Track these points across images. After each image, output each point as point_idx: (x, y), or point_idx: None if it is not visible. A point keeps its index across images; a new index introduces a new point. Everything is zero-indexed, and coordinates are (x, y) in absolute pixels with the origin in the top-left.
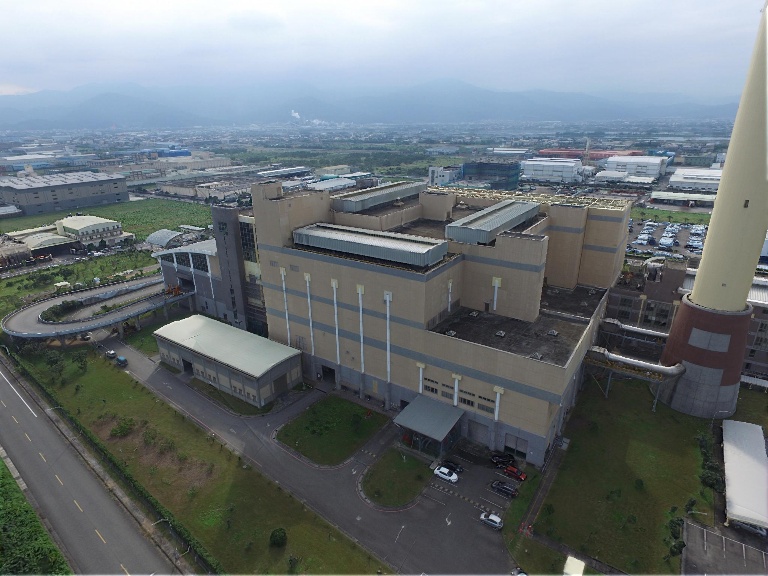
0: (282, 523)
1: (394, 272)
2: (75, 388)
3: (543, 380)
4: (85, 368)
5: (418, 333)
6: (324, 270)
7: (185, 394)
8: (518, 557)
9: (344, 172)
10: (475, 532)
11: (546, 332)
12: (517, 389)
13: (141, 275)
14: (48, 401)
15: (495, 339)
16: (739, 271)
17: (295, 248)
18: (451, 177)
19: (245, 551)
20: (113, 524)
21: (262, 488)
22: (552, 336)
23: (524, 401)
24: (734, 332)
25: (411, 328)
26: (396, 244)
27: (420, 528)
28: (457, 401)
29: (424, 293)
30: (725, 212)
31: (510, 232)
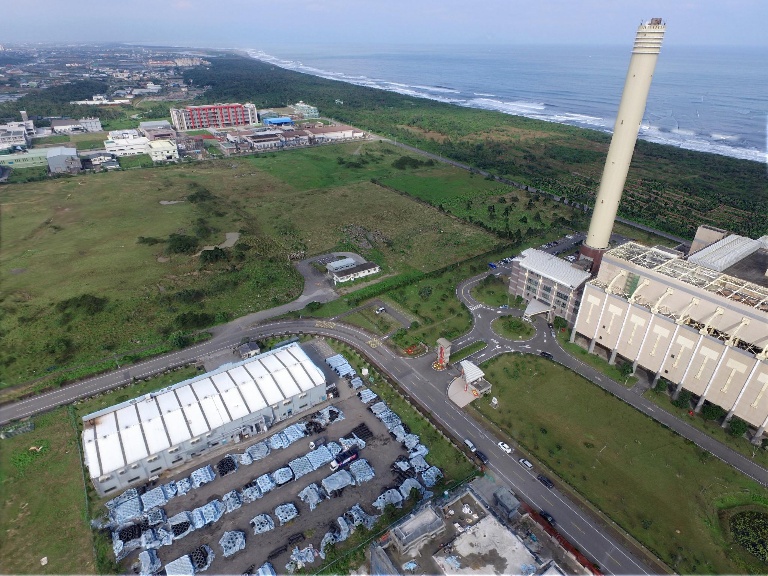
0: None
1: None
2: None
3: None
4: None
5: None
6: None
7: None
8: None
9: None
10: None
11: None
12: None
13: None
14: None
15: None
16: None
17: None
18: None
19: None
20: None
21: None
22: None
23: None
24: None
25: None
26: None
27: None
28: None
29: None
30: None
31: (720, 232)
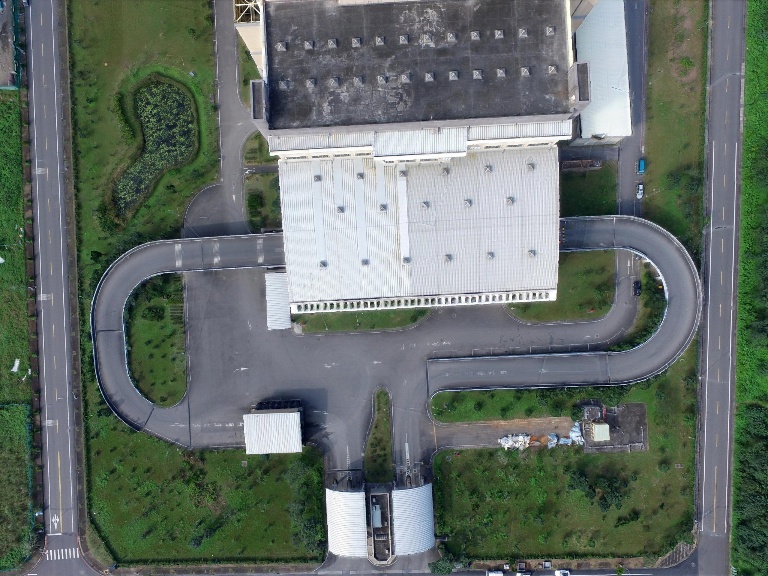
0: None
1: None
2: None
3: None
4: None
5: None
6: None
7: (631, 76)
8: None
9: None
10: None
11: None
12: None
13: (505, 410)
14: None
15: None
16: None
17: None
18: None
19: None
20: None
21: None
22: None
23: None
24: None
25: None
26: None
27: None
28: None
29: None
30: None
31: None
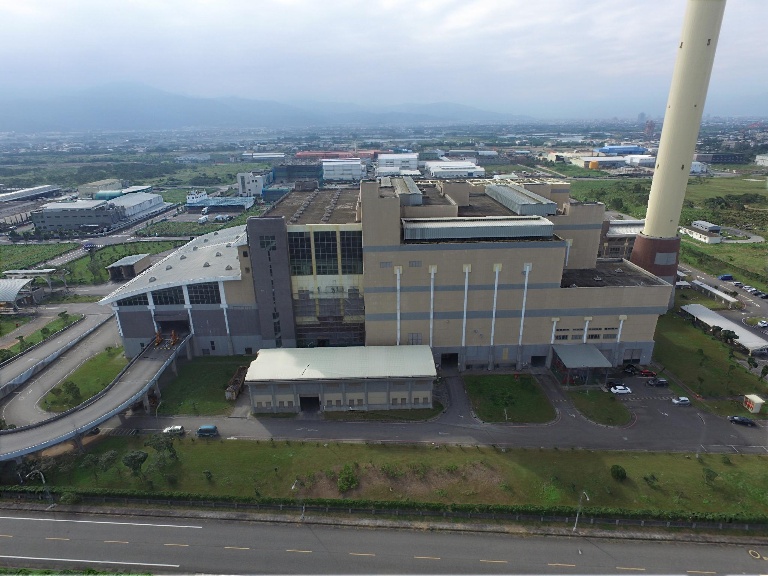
0: (598, 466)
1: (537, 244)
2: (208, 476)
3: (657, 299)
4: (175, 455)
5: (555, 292)
6: (455, 258)
7: (341, 428)
8: (718, 412)
9: (116, 187)
10: (683, 412)
11: (614, 272)
12: (636, 312)
13: None
14: (186, 507)
15: (600, 283)
16: (678, 210)
17: (417, 243)
18: (264, 182)
19: (611, 495)
20: (486, 547)
21: (542, 456)
22: (621, 273)
23: (641, 320)
24: (677, 250)
25: (548, 290)
26: (519, 222)
27: (660, 425)
28: (586, 339)
29: (564, 256)
30: (670, 174)
31: None
